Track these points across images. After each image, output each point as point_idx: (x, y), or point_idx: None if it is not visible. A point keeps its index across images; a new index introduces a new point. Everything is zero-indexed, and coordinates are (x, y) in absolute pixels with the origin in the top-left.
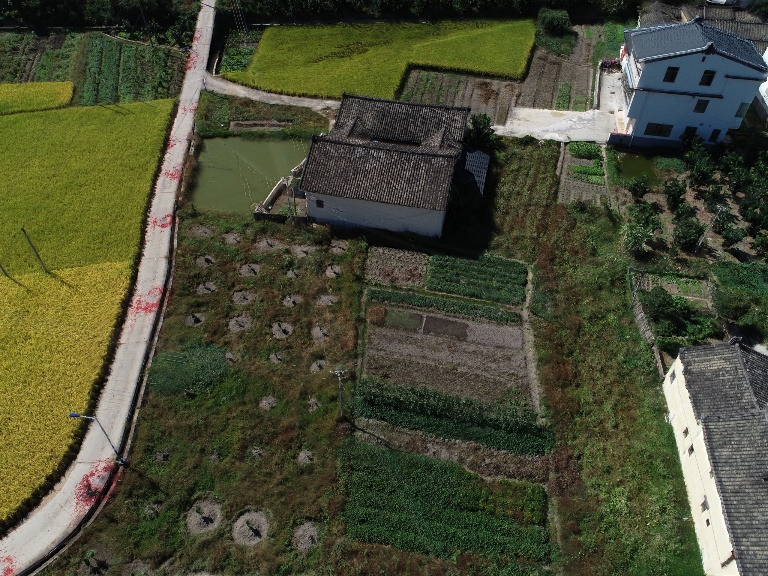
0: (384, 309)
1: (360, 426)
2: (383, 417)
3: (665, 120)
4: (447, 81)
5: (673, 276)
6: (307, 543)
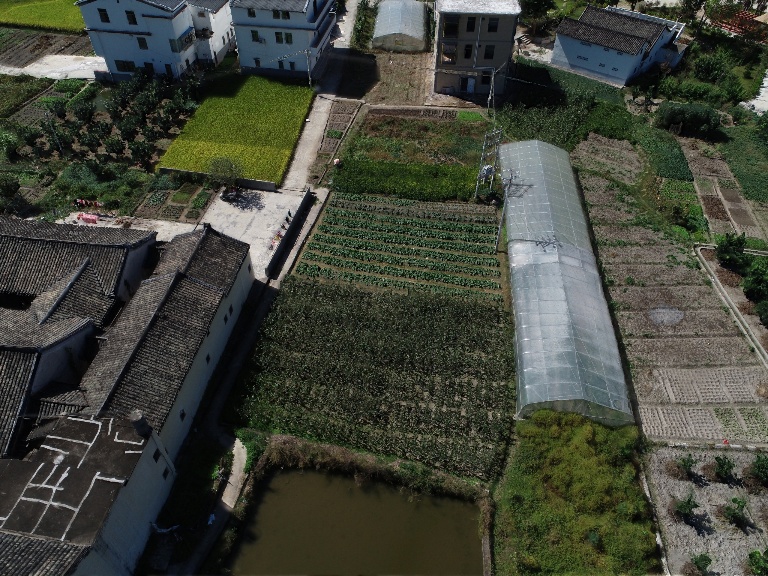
0: None
1: None
2: None
3: (125, 57)
4: (18, 36)
5: (25, 173)
6: None
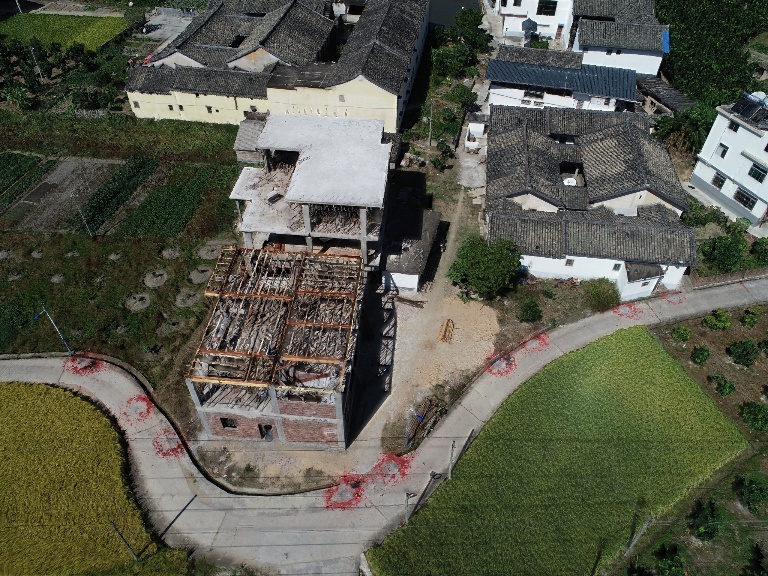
0: (1, 219)
1: (103, 233)
2: (102, 220)
3: None
4: None
5: (60, 100)
6: (175, 252)
